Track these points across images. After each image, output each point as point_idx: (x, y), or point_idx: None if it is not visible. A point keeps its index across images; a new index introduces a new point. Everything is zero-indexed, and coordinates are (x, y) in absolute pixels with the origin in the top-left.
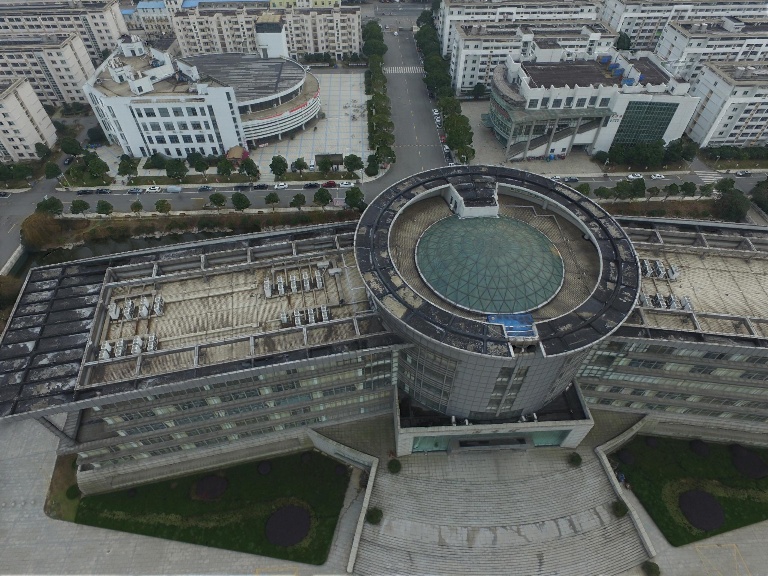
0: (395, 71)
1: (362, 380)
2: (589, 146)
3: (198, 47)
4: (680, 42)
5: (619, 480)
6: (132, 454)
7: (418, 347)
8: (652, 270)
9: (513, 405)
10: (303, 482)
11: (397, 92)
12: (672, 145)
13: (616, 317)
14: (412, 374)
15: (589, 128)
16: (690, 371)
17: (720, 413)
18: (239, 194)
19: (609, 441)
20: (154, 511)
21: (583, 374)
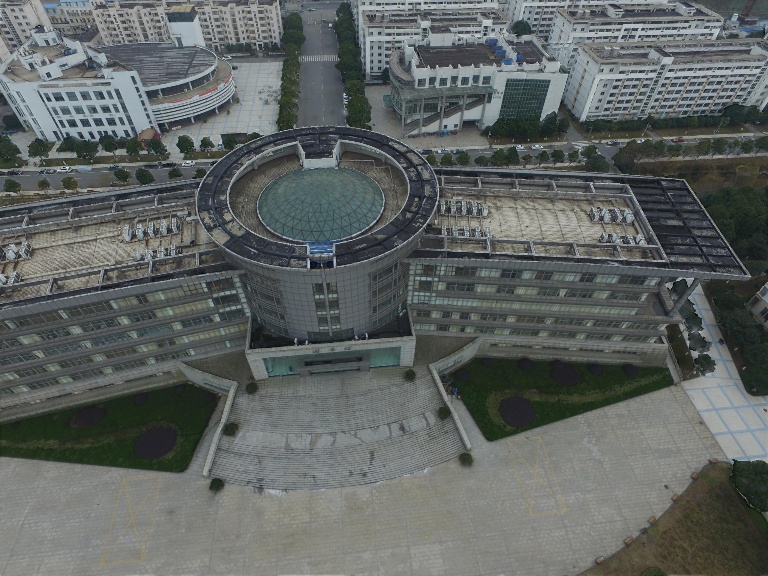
0: (313, 59)
1: (214, 310)
2: (479, 122)
3: (121, 39)
4: (567, 27)
5: (453, 393)
6: (10, 387)
7: (247, 272)
8: (468, 209)
9: (341, 324)
10: (174, 408)
11: (312, 78)
12: (547, 118)
13: (405, 237)
14: None
15: (476, 105)
16: (497, 292)
17: (537, 332)
18: (142, 170)
19: (441, 359)
20: (34, 438)
21: (414, 301)
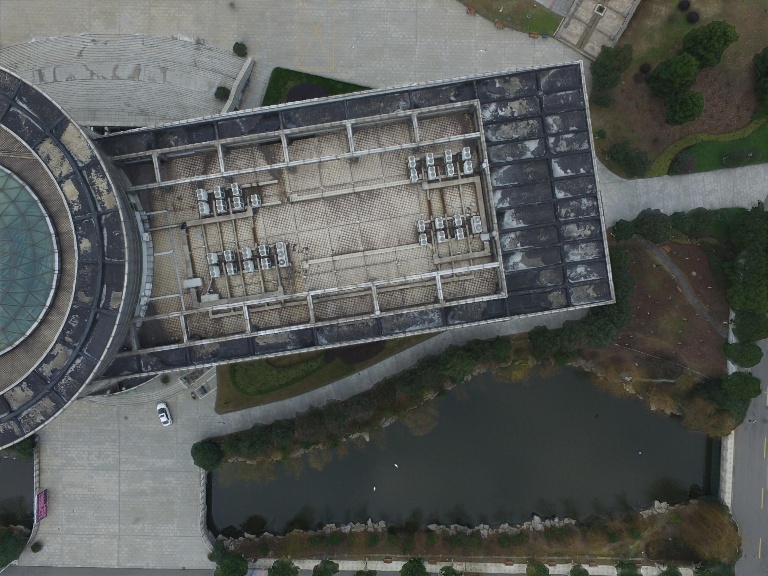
0: None
1: None
2: None
3: None
4: None
5: None
6: None
7: None
8: None
9: None
10: None
11: None
12: None
13: None
14: None
15: None
16: None
17: None
18: None
19: None
20: None
21: None
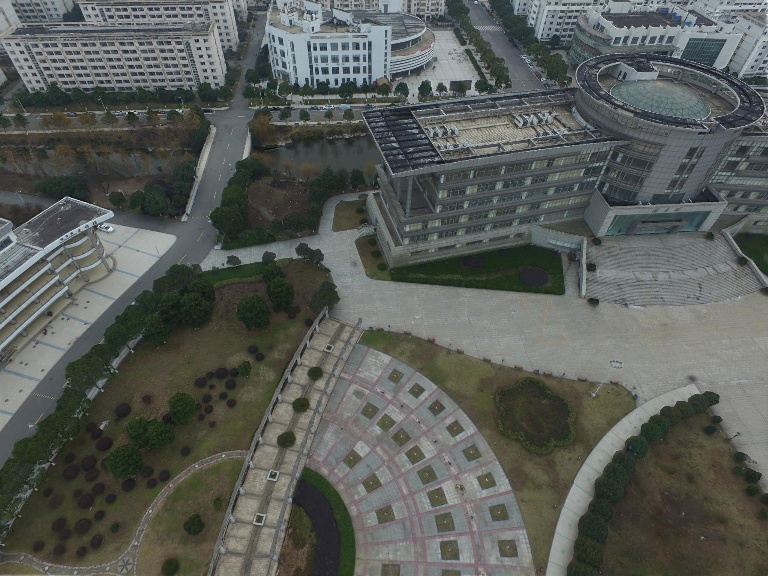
0: None
1: (583, 179)
2: None
3: None
4: (713, 1)
5: None
6: None
7: (634, 142)
8: None
9: (682, 187)
10: (533, 258)
11: None
12: None
13: (757, 116)
14: (616, 172)
15: None
16: None
17: None
18: None
19: (729, 226)
20: (443, 273)
21: (713, 181)
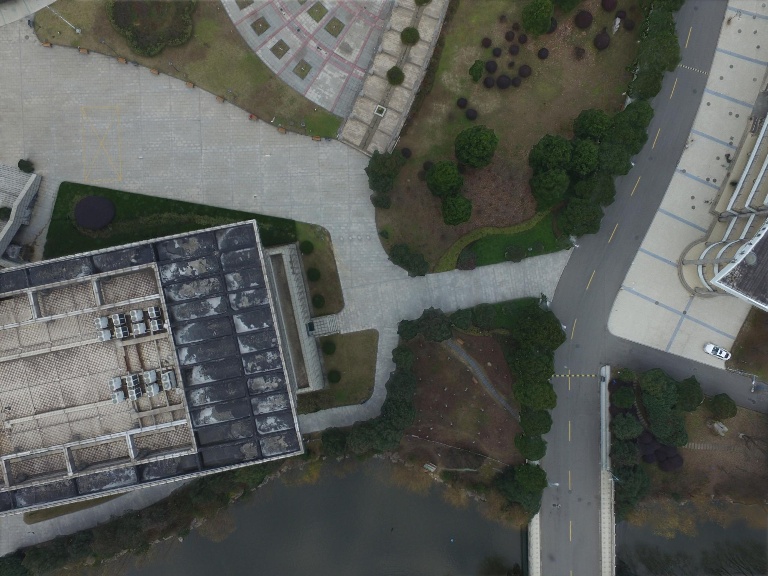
0: None
1: None
2: None
3: None
4: None
5: None
6: None
7: None
8: None
9: None
10: None
11: None
12: None
13: None
14: None
15: None
16: None
17: None
18: None
19: None
20: None
21: None
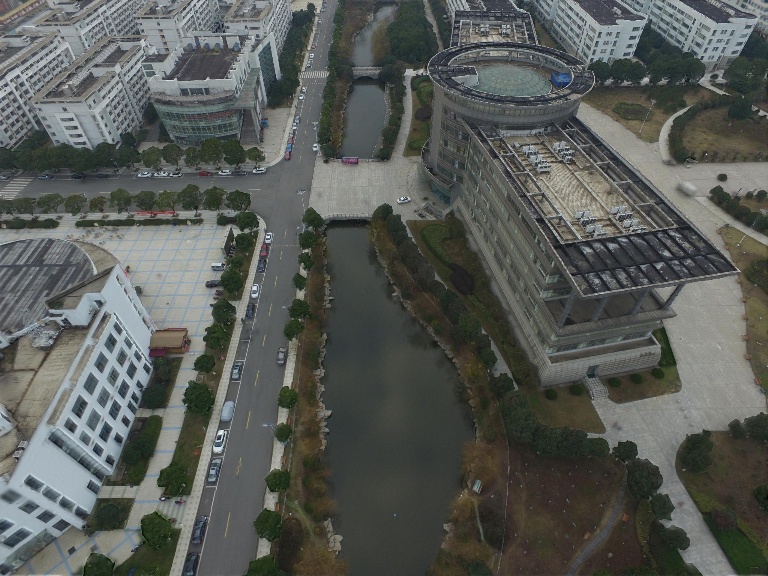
0: None
1: None
2: None
3: None
4: (166, 24)
5: None
6: None
7: None
8: None
9: None
10: None
11: None
12: None
13: (552, 51)
14: None
15: None
16: None
17: None
18: None
19: None
20: None
21: None
